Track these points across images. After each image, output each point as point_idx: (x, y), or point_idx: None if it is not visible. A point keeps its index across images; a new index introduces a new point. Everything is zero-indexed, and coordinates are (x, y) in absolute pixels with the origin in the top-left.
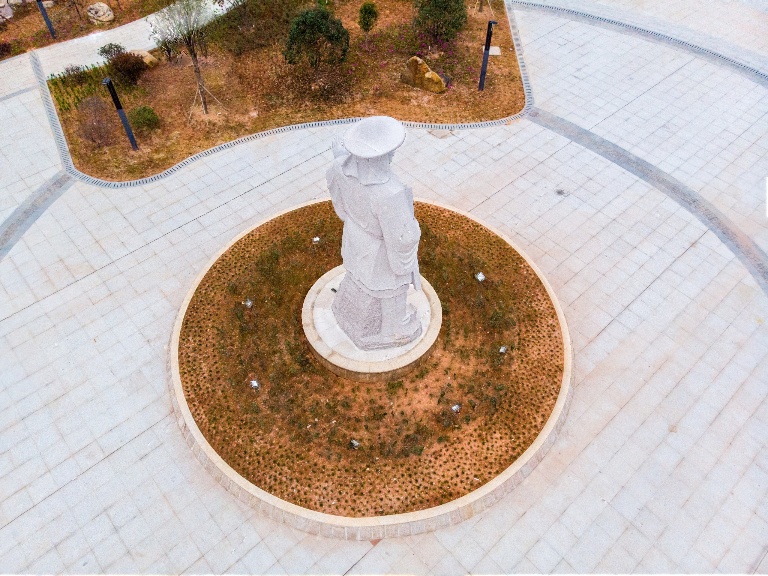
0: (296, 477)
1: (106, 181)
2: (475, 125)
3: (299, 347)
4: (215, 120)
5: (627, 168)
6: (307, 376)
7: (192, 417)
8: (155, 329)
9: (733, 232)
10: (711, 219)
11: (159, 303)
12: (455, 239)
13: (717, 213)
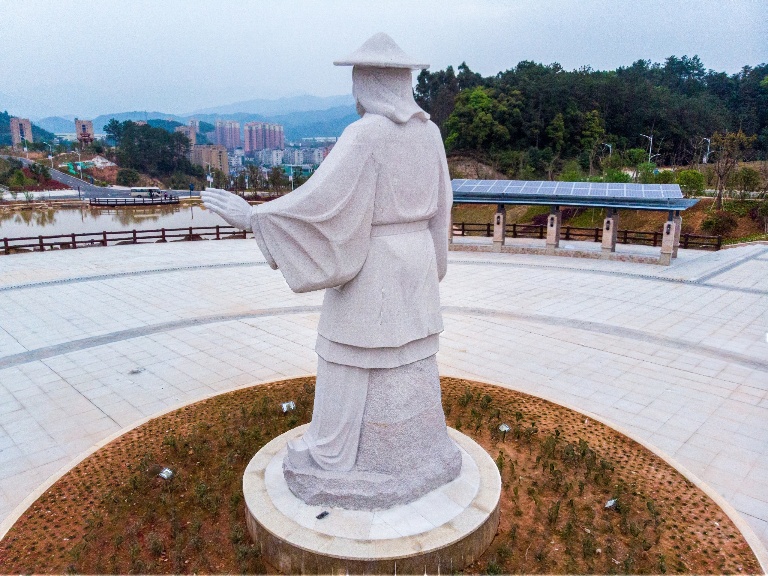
0: (718, 569)
1: None
2: None
3: None
4: None
5: (122, 339)
6: (515, 574)
7: None
8: None
9: (244, 314)
10: (224, 318)
11: None
12: (200, 428)
13: (217, 316)
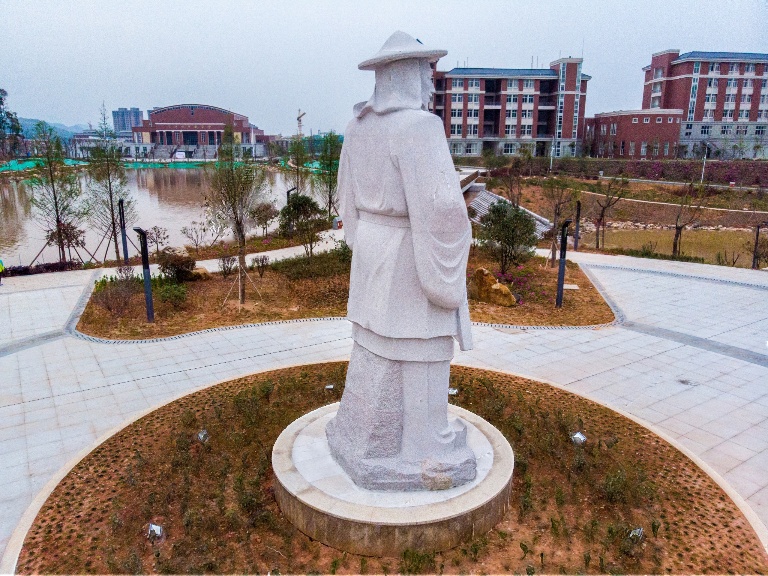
0: None
1: (100, 339)
2: (554, 328)
3: (258, 494)
4: (249, 308)
5: None
6: (255, 533)
7: (13, 571)
8: (52, 463)
9: None
10: None
11: (80, 437)
12: (533, 402)
13: None
